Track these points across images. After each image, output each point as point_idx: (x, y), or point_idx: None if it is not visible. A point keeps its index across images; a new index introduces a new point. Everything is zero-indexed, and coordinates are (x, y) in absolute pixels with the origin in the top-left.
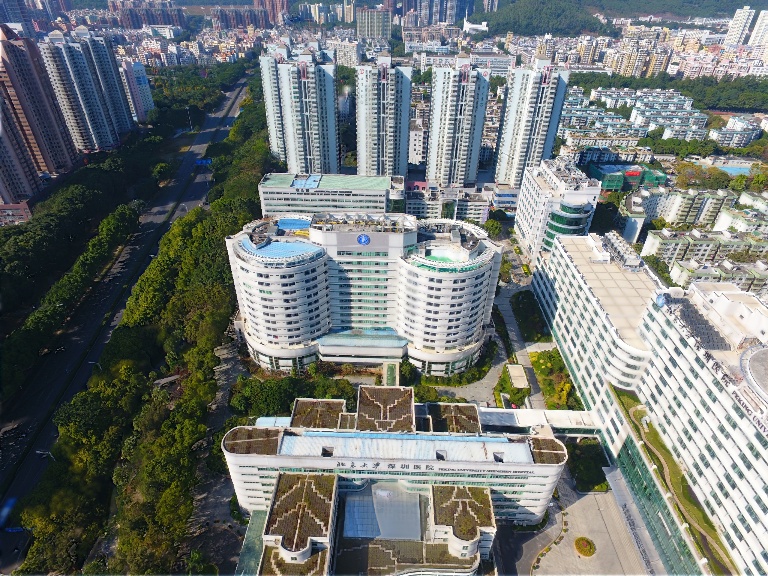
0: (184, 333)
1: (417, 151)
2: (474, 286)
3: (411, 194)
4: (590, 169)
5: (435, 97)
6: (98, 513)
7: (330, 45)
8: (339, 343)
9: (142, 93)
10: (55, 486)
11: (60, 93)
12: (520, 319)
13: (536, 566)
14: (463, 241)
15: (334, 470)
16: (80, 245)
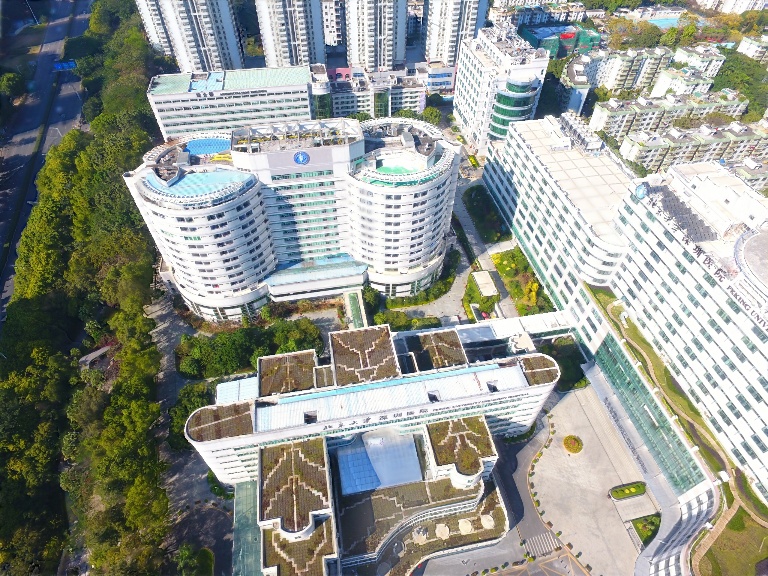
0: (101, 297)
1: (330, 28)
2: (436, 197)
3: (336, 85)
4: (523, 34)
5: None
6: (54, 525)
7: None
8: (291, 280)
9: None
10: None
11: None
12: (476, 219)
13: (531, 473)
14: (417, 144)
15: (321, 433)
16: None
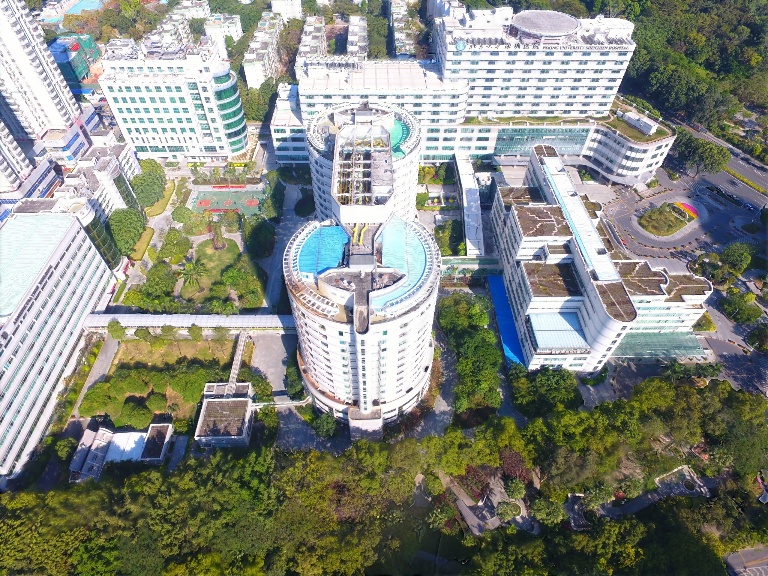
0: None
1: None
2: None
3: None
4: None
5: None
6: None
7: None
8: None
9: None
10: (676, 569)
11: None
12: None
13: None
14: None
15: None
16: None
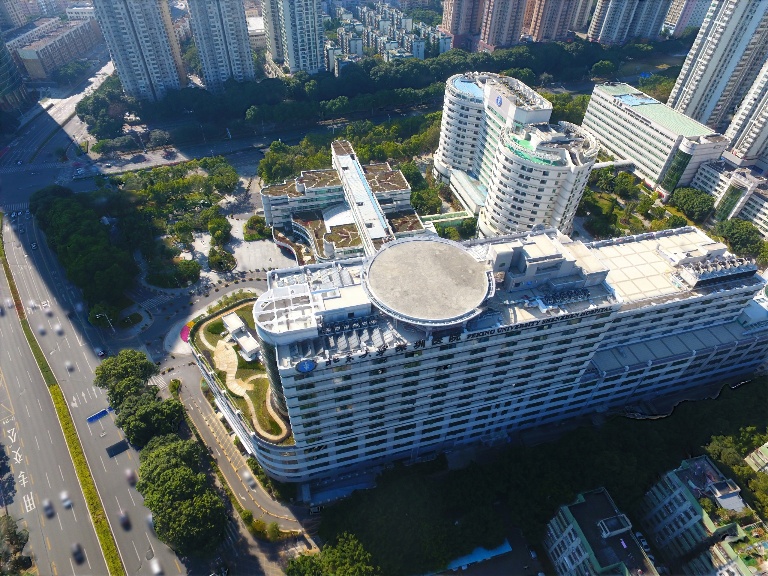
0: None
1: None
2: (519, 175)
3: (723, 164)
4: None
5: None
6: None
7: None
8: (459, 178)
9: (697, 8)
10: (323, 139)
11: None
12: None
13: None
14: (556, 143)
15: (342, 181)
16: None
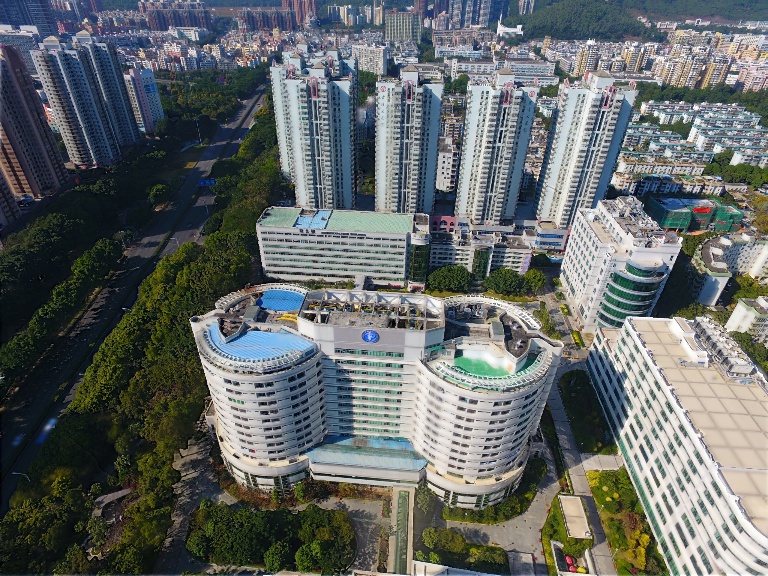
0: None
1: (445, 175)
2: (522, 407)
3: (437, 236)
4: (649, 202)
5: (470, 120)
6: None
7: (351, 54)
8: (335, 460)
9: (151, 102)
10: None
11: (55, 104)
12: (573, 415)
13: None
14: (507, 338)
15: None
16: (54, 284)
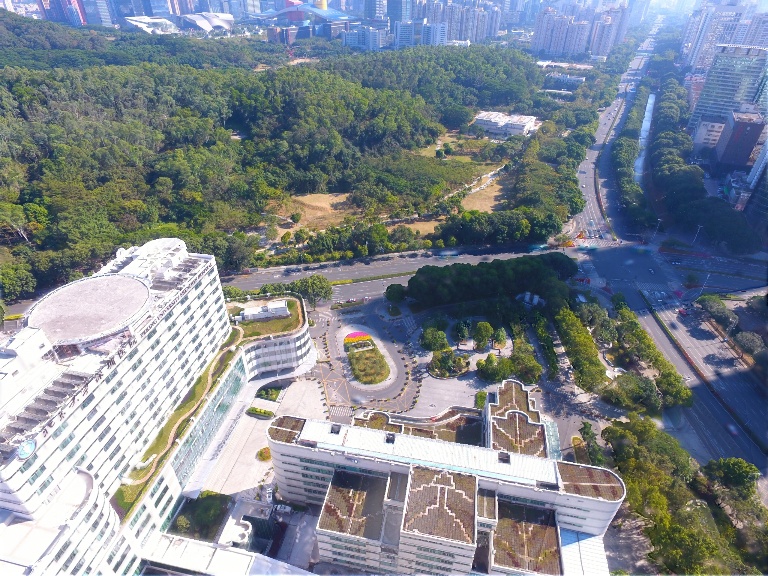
0: None
1: None
2: None
3: None
4: None
5: None
6: None
7: None
8: None
9: None
10: None
11: None
12: None
13: None
14: None
15: None
16: None
